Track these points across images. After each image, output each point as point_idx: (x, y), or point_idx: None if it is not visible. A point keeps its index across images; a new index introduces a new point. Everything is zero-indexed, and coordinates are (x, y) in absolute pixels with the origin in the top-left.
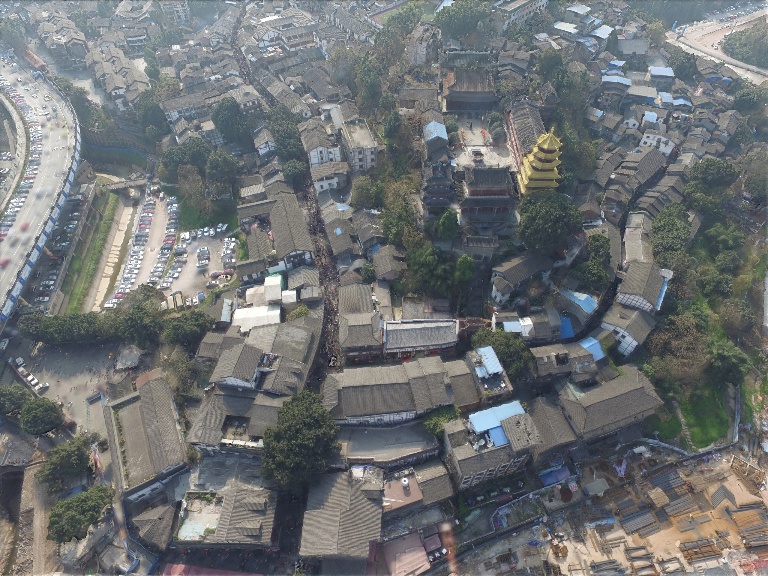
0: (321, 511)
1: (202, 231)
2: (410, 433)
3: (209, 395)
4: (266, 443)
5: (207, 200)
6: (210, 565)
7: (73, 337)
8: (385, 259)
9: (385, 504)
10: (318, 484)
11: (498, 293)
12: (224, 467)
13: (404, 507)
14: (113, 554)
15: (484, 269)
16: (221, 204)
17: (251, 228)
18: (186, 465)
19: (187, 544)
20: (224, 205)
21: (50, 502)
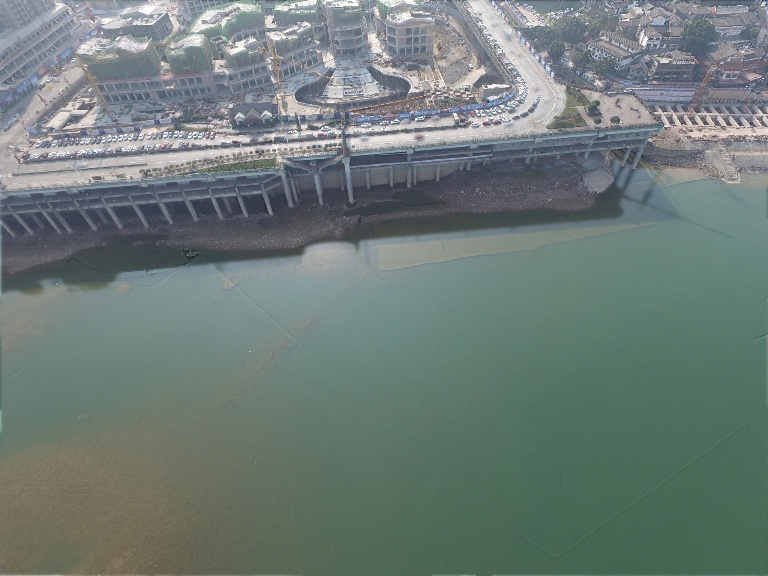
0: (719, 50)
1: (559, 12)
2: (740, 38)
3: (646, 27)
4: (689, 30)
5: None
6: (666, 81)
7: (540, 35)
8: None
9: None
10: (709, 49)
11: None
12: None
13: (748, 55)
14: (617, 85)
15: None
16: None
17: None
18: (642, 52)
19: (663, 65)
20: None
21: None
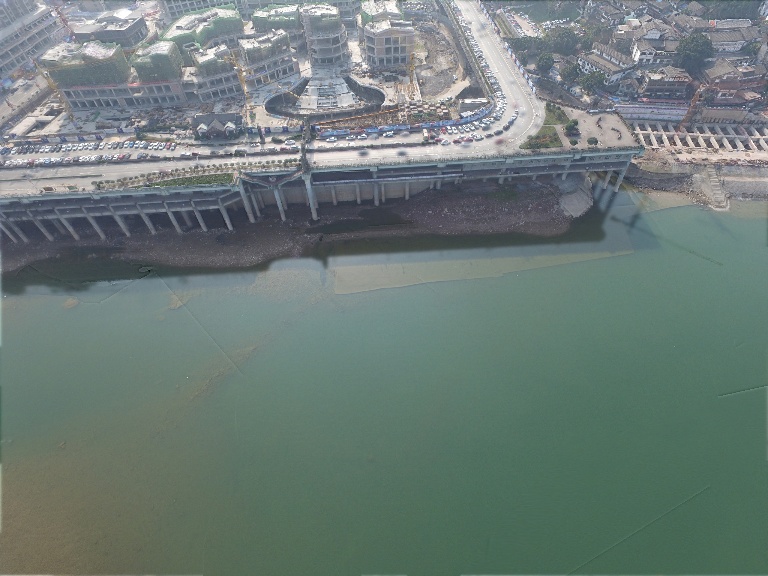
0: (715, 67)
1: (555, 21)
2: None
3: None
4: (684, 45)
5: (556, 5)
6: None
7: (531, 46)
8: (696, 5)
9: (741, 69)
10: (705, 65)
11: (767, 9)
12: (654, 66)
13: (747, 73)
14: (605, 101)
15: (754, 4)
16: (566, 6)
17: (601, 7)
18: None
19: (654, 82)
20: (567, 7)
21: (553, 98)
